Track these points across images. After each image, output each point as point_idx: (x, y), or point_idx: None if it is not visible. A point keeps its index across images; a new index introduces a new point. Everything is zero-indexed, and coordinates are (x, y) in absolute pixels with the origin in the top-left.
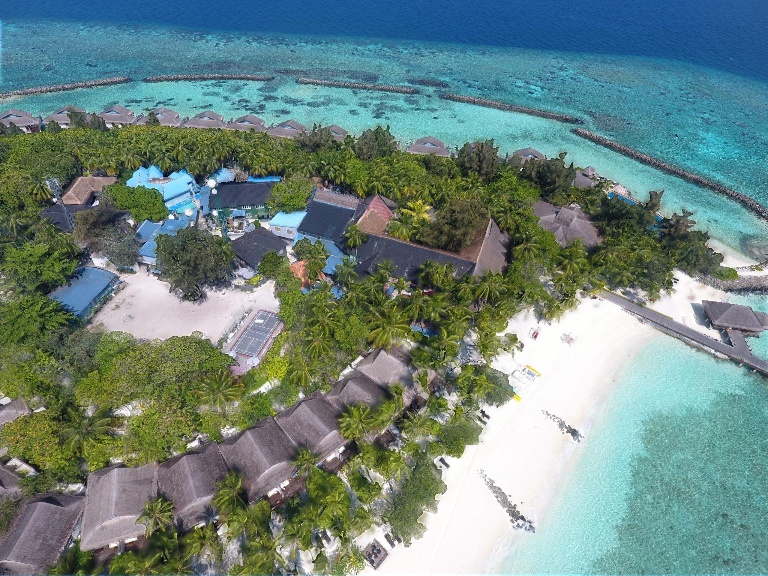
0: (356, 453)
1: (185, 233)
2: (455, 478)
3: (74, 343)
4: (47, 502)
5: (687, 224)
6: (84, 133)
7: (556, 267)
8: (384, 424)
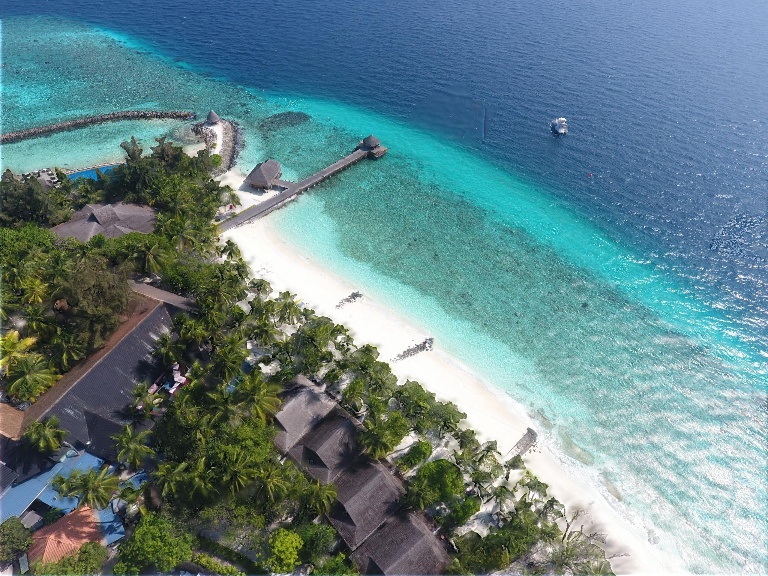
0: (384, 459)
1: None
2: (400, 380)
3: None
4: None
5: (168, 148)
6: None
7: (179, 247)
8: (383, 410)
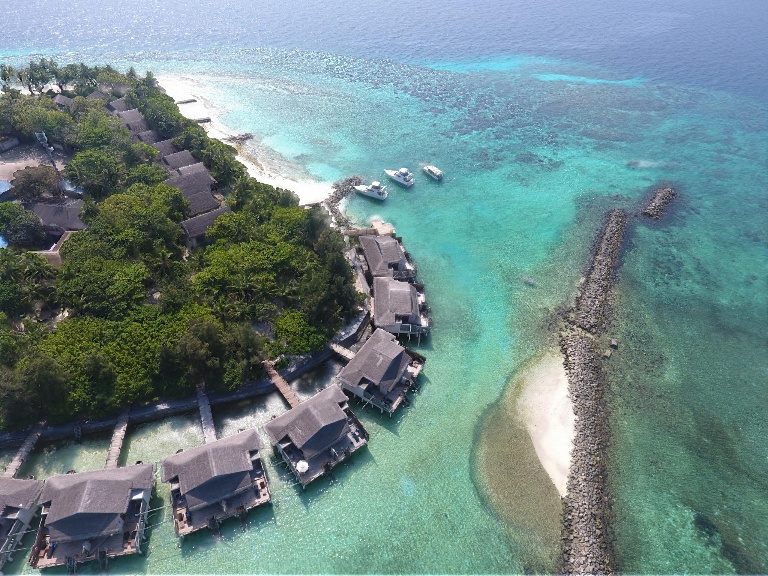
0: None
1: None
2: None
3: None
4: None
5: None
6: (41, 347)
7: None
8: None
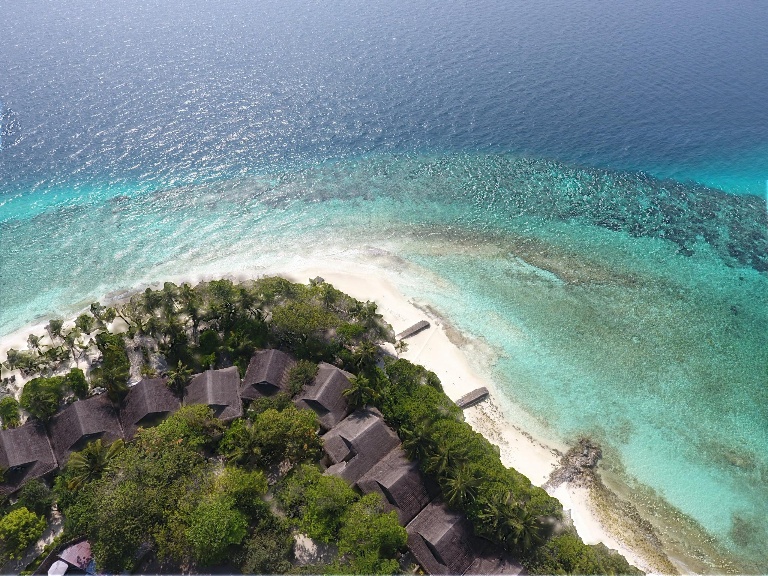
0: None
1: None
2: None
3: (292, 571)
4: (267, 390)
5: None
6: None
7: None
8: None
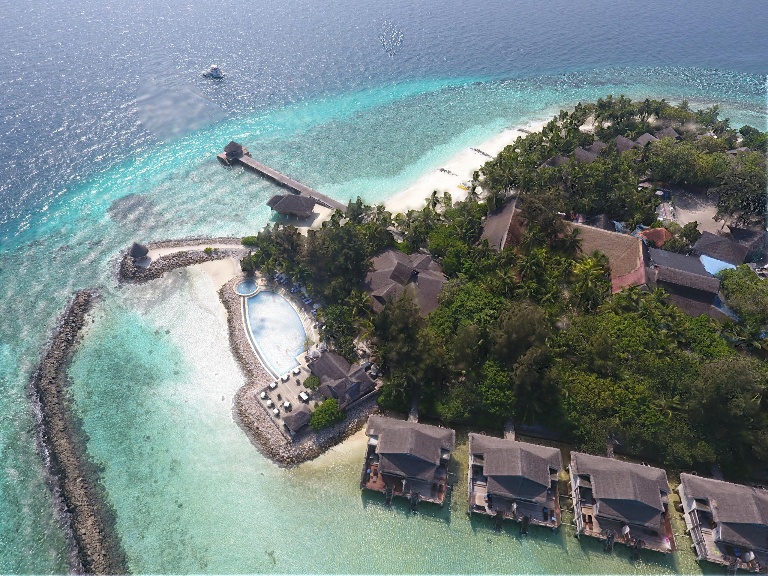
0: None
1: (763, 181)
2: None
3: None
4: (678, 142)
5: None
6: None
7: None
8: None
